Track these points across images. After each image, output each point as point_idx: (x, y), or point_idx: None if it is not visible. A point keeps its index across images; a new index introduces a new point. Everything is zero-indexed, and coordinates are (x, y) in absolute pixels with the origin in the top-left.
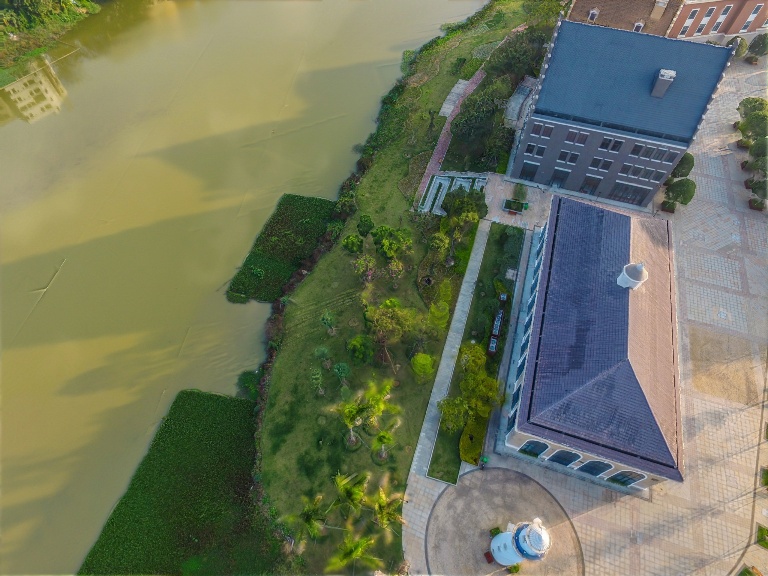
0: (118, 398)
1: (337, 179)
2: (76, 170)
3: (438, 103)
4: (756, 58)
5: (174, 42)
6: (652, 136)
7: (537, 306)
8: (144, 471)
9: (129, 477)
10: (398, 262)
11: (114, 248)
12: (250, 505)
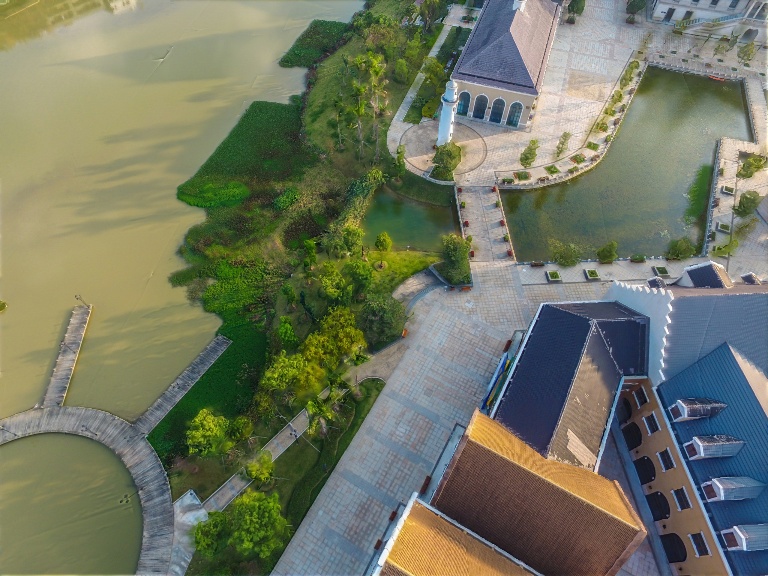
0: (217, 103)
1: (350, 14)
2: (172, 6)
3: None
4: None
5: None
6: None
7: None
8: (237, 129)
9: (228, 132)
10: None
11: (204, 42)
12: (300, 142)
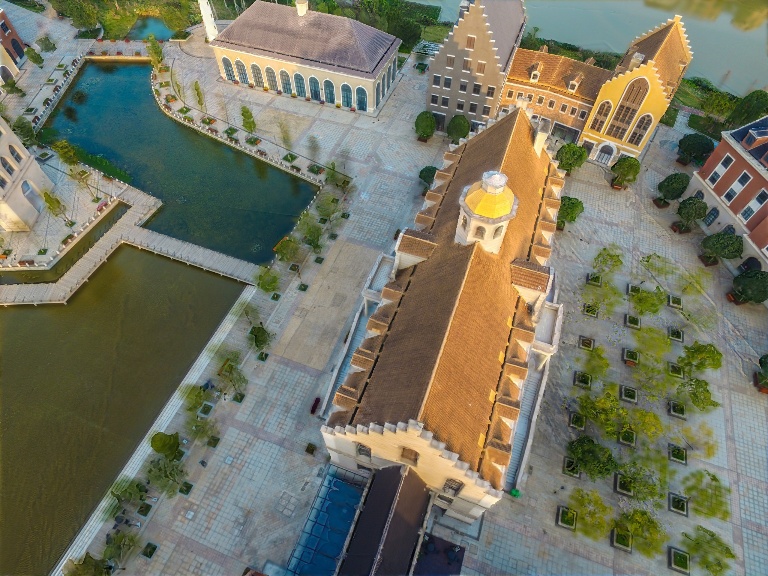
0: None
1: None
2: None
3: None
4: None
5: None
6: None
7: None
8: None
9: None
10: (362, 7)
11: None
12: None
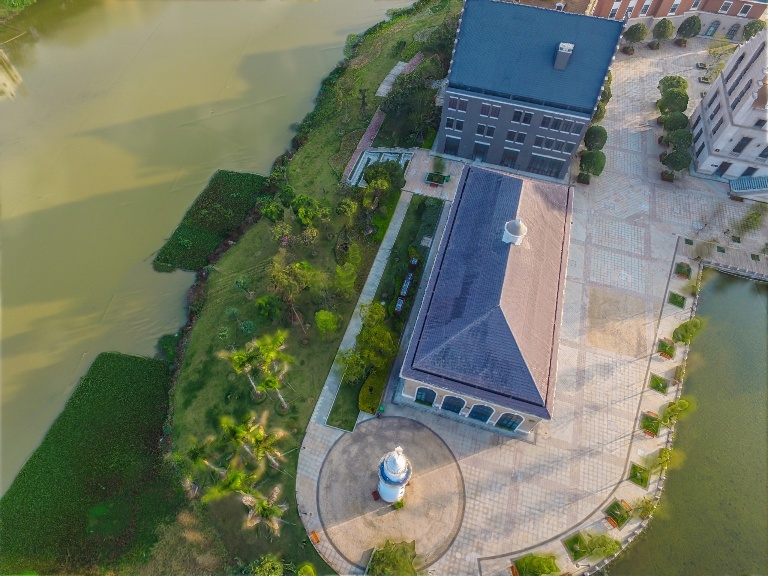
0: (39, 360)
1: (271, 156)
2: (14, 148)
3: (376, 84)
4: (684, 40)
5: (122, 26)
6: (558, 108)
7: (435, 265)
8: (59, 426)
9: (44, 432)
10: (313, 229)
11: (46, 222)
12: (159, 456)
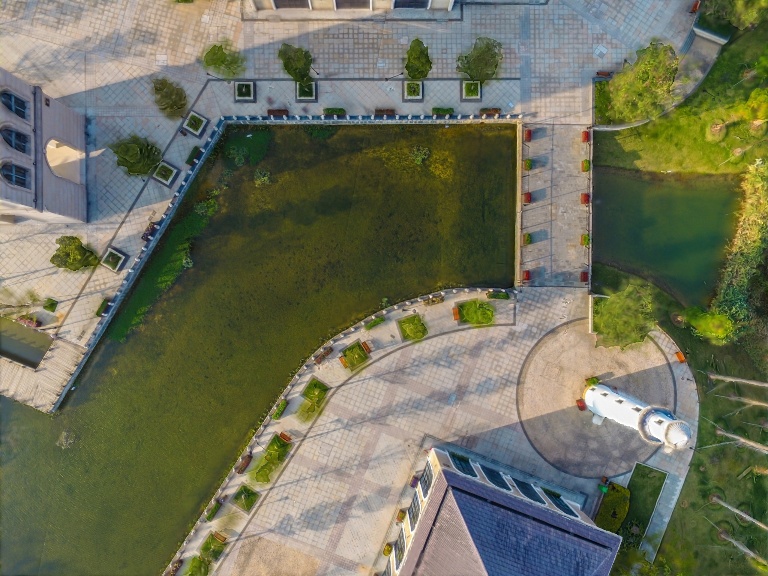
0: None
1: None
2: None
3: None
4: None
5: None
6: None
7: None
8: None
9: None
10: None
11: None
12: None
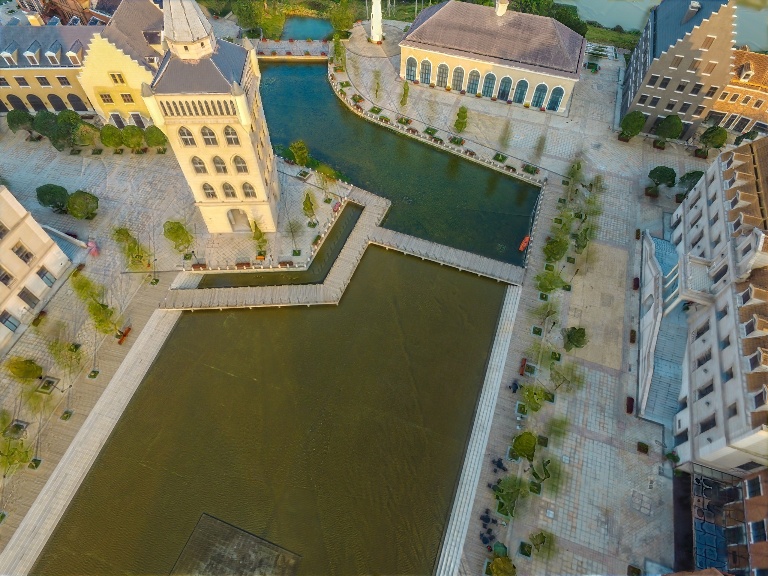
0: None
1: (599, 23)
2: None
3: None
4: None
5: None
6: None
7: None
8: None
9: None
10: (519, 6)
11: None
12: (397, 3)
